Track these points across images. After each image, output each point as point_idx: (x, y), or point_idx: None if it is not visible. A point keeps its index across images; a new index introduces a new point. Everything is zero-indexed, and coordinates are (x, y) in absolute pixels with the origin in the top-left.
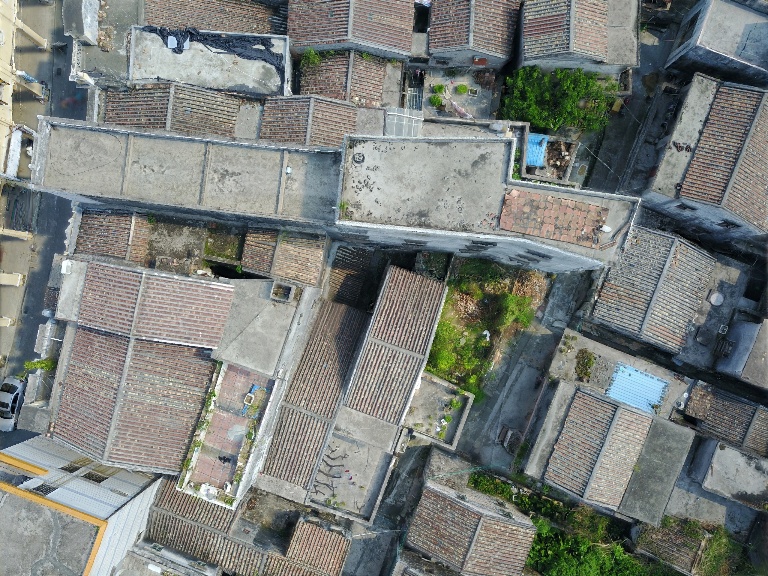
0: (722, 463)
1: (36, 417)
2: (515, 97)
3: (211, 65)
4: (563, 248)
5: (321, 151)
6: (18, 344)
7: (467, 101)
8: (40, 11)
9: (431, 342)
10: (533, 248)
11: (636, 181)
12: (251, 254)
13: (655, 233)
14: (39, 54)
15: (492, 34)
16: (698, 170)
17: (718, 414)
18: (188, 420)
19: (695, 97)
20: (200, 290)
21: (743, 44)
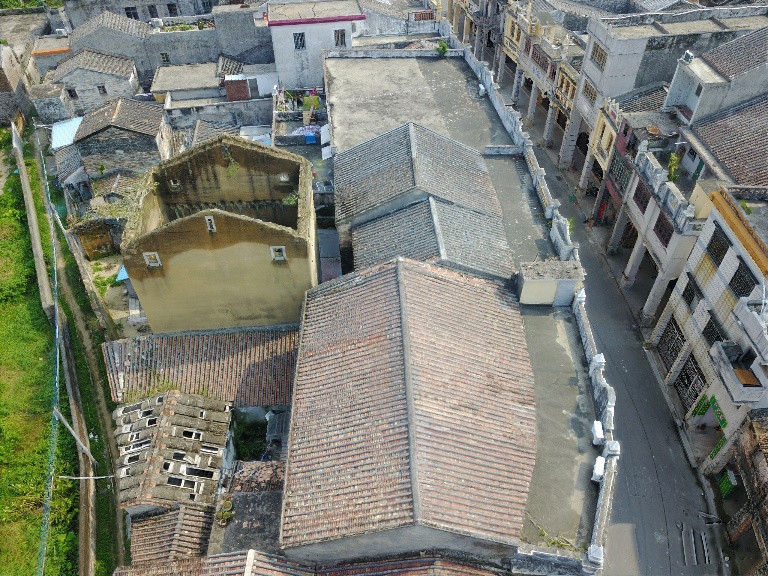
0: None
1: (718, 185)
2: None
3: None
4: None
5: None
6: None
7: None
8: None
9: None
10: None
11: None
12: None
13: None
14: None
15: None
16: None
17: None
18: None
19: None
20: None
21: None
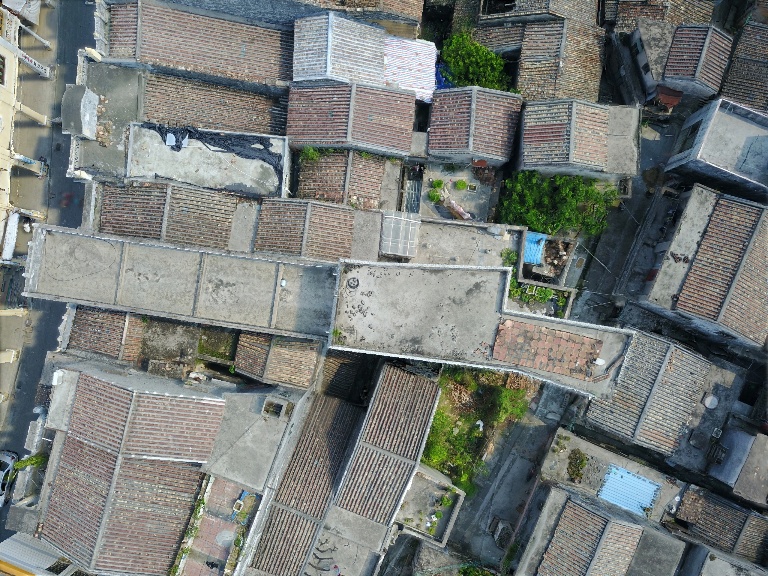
0: (712, 574)
1: (24, 518)
2: (514, 200)
3: (209, 163)
4: (556, 379)
5: (316, 266)
6: (10, 419)
7: (466, 196)
8: (41, 86)
9: (423, 447)
10: None
11: (633, 283)
12: (244, 355)
13: (651, 337)
14: (39, 129)
15: (492, 137)
16: (695, 283)
17: (709, 518)
18: (177, 526)
19: (694, 208)
20: (191, 406)
21: (744, 157)
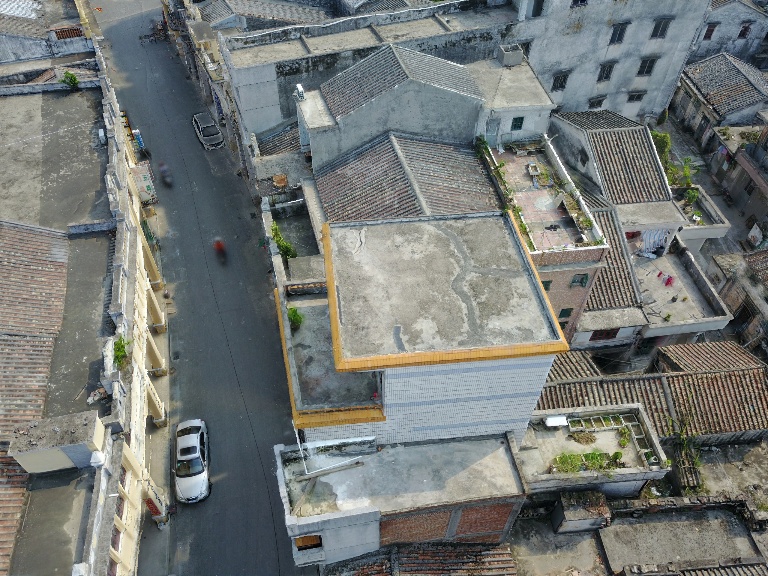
0: None
1: (312, 264)
2: None
3: None
4: None
5: (465, 1)
6: (177, 394)
7: None
8: None
9: None
10: (660, 6)
11: None
12: None
13: (706, 60)
14: None
15: None
16: None
17: None
18: None
19: None
20: None
21: None
